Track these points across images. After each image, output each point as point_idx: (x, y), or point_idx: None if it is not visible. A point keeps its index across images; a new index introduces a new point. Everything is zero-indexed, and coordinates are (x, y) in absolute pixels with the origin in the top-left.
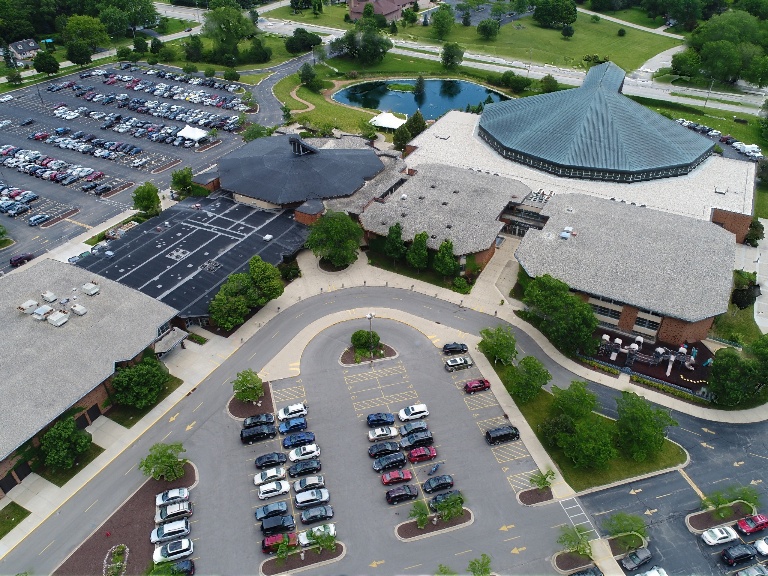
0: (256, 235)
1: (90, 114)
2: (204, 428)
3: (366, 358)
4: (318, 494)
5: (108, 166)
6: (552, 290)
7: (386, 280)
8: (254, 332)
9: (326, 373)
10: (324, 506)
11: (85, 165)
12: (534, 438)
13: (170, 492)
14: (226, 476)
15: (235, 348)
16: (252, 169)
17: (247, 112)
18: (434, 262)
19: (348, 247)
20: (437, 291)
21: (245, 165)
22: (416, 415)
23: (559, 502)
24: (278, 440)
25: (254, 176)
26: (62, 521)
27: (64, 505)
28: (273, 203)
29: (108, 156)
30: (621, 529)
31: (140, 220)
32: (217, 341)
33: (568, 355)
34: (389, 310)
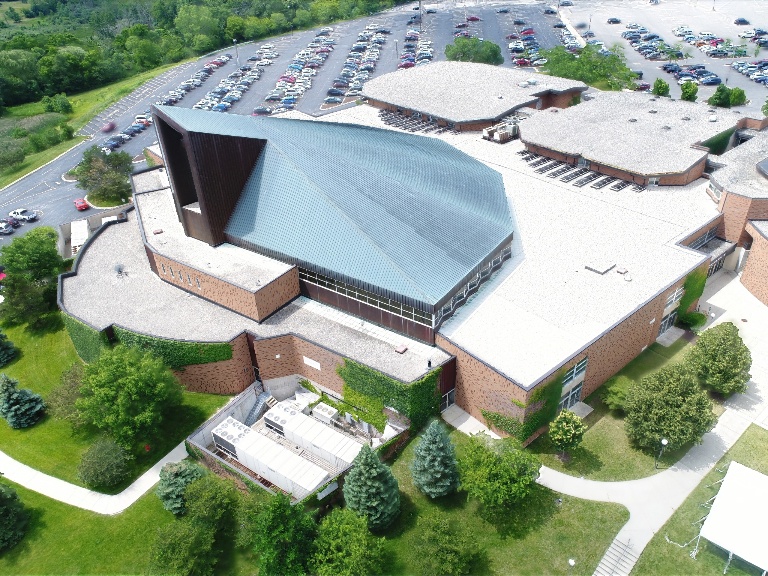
0: None
1: None
2: None
3: None
4: None
5: None
6: None
7: None
8: None
9: (760, 97)
10: None
11: None
12: None
13: None
14: None
15: None
16: None
17: None
18: None
19: None
20: None
21: None
22: None
23: None
24: None
25: None
26: None
27: None
28: None
29: None
30: None
31: None
32: None
33: None
34: None
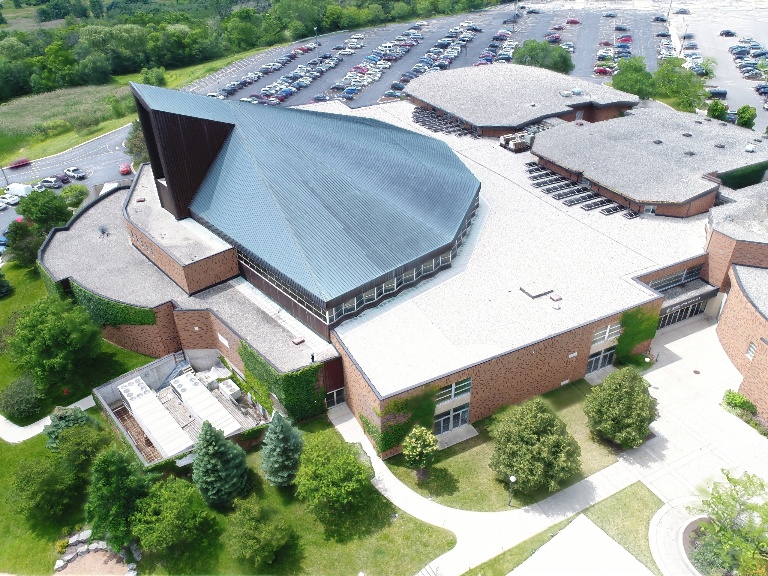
0: None
1: None
2: None
3: None
4: None
5: None
6: None
7: None
8: None
9: None
10: None
11: None
12: None
13: None
14: None
15: None
16: None
17: None
18: None
19: None
20: None
21: None
22: None
23: None
24: None
25: None
26: None
27: None
28: None
29: None
30: None
31: None
32: None
33: None
34: None
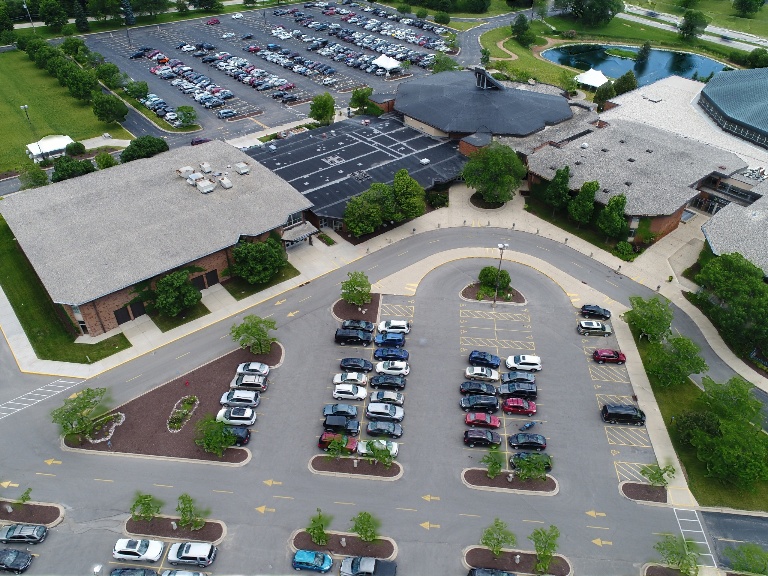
0: (414, 157)
1: (301, 37)
2: (304, 319)
3: (490, 297)
4: (392, 410)
5: (301, 81)
6: (739, 271)
7: (538, 228)
8: (383, 246)
9: (442, 301)
10: (394, 423)
11: (282, 77)
12: (663, 430)
13: (252, 364)
14: (309, 367)
15: (359, 256)
16: (430, 95)
17: (447, 53)
18: (599, 218)
19: (504, 183)
20: (594, 251)
21: (424, 91)
22: (526, 366)
23: (673, 509)
24: (371, 349)
25: (429, 102)
26: (154, 361)
27: (160, 348)
28: (440, 129)
29: (304, 72)
30: (750, 567)
31: (312, 128)
32: (344, 246)
33: (739, 354)
34: (532, 258)
